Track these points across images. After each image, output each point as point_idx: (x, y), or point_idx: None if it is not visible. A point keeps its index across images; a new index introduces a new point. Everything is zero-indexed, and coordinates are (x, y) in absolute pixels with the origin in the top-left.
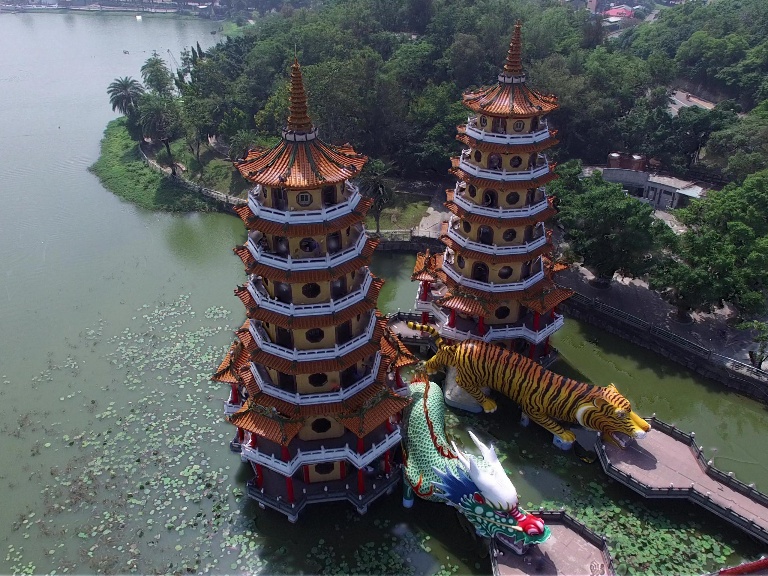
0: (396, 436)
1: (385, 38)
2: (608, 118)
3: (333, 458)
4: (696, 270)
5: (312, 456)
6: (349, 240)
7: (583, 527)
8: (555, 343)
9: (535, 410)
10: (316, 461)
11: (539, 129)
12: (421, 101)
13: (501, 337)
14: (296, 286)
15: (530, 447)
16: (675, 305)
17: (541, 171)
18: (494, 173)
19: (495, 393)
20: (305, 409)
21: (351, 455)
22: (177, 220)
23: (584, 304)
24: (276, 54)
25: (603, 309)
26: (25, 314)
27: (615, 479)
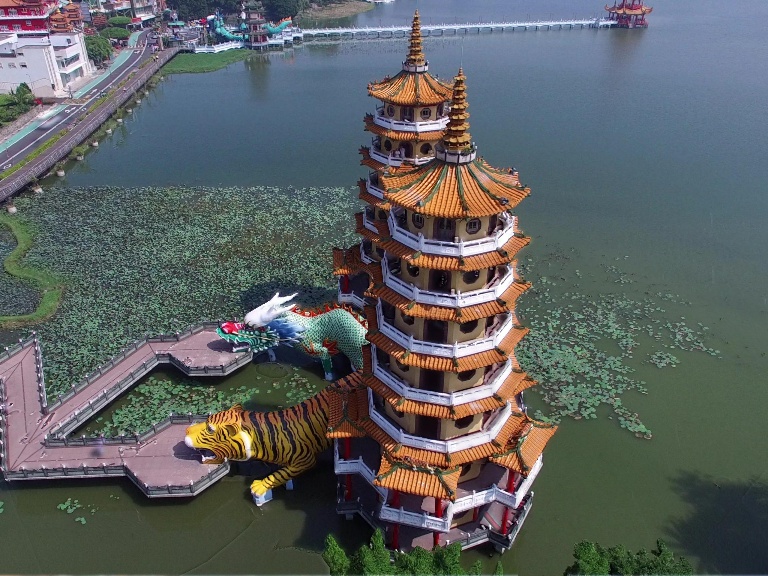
0: None
1: None
2: None
3: None
4: None
5: None
6: None
7: None
8: None
9: None
10: None
11: (406, 224)
12: None
13: None
14: None
15: None
16: None
17: None
18: None
19: None
20: None
21: None
22: None
23: None
24: None
25: None
26: (725, 277)
27: None
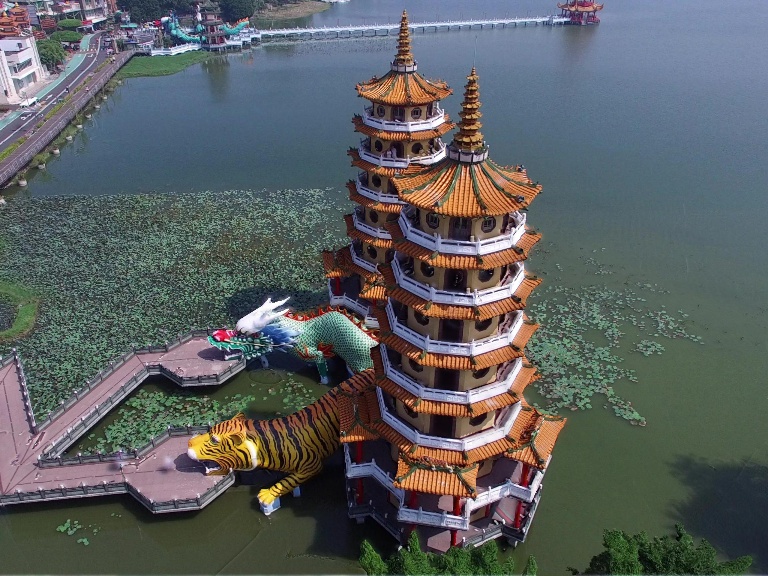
0: None
1: None
2: None
3: None
4: None
5: None
6: (373, 150)
7: None
8: None
9: None
10: None
11: (419, 225)
12: None
13: None
14: None
15: None
16: None
17: None
18: None
19: None
20: None
21: None
22: None
23: None
24: None
25: None
26: (699, 265)
27: None
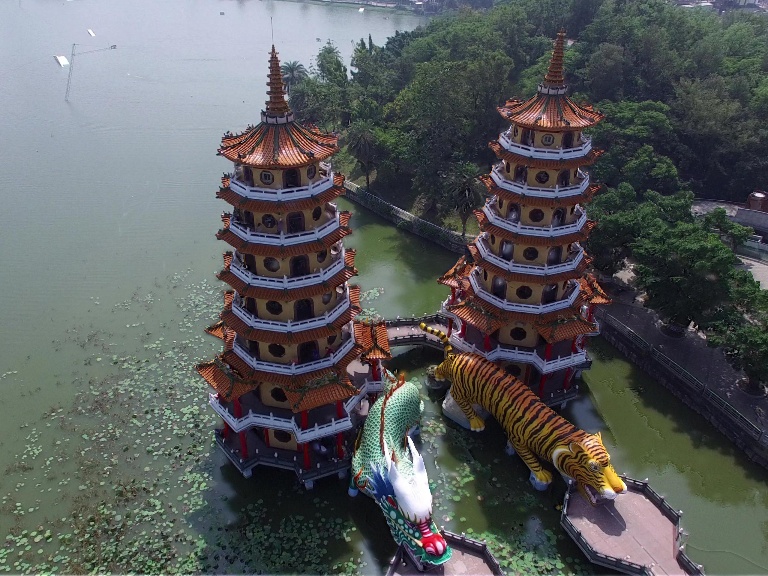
0: (345, 423)
1: (538, 43)
2: (765, 152)
3: (280, 427)
4: (765, 335)
5: (262, 420)
6: (314, 224)
7: (497, 566)
8: (592, 382)
9: (516, 440)
10: (265, 425)
11: (574, 146)
12: None
13: (509, 358)
14: (258, 258)
15: (503, 476)
16: (744, 371)
17: (571, 191)
18: (516, 186)
19: (485, 413)
20: (259, 374)
21: (295, 428)
22: None
23: (642, 348)
24: (427, 51)
25: (659, 358)
26: (138, 252)
27: (567, 532)
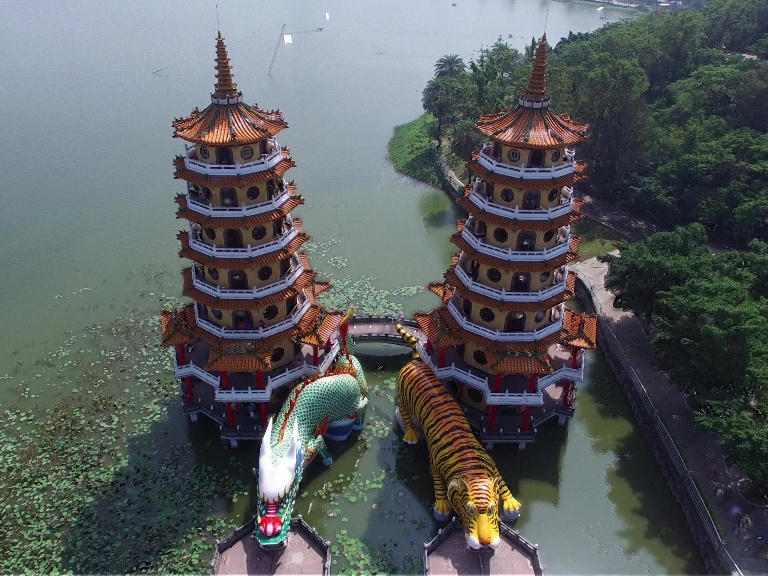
0: (263, 395)
1: (706, 55)
2: None
3: (211, 382)
4: (757, 430)
5: (199, 372)
6: (247, 202)
7: (326, 569)
8: (575, 433)
9: (431, 462)
10: (201, 377)
11: (546, 166)
12: (676, 132)
13: (462, 379)
14: None
15: (412, 494)
16: None
17: (535, 215)
18: (481, 200)
19: None
20: (199, 330)
21: None
22: (406, 185)
23: (648, 412)
24: (581, 55)
25: (660, 428)
26: None
27: (423, 566)
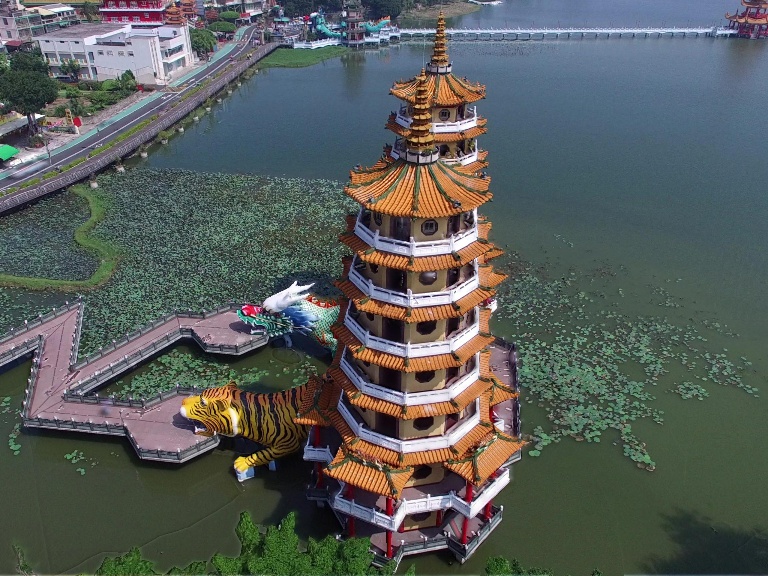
0: None
1: None
2: None
3: None
4: None
5: None
6: None
7: None
8: None
9: None
10: None
11: (370, 220)
12: None
13: None
14: None
15: None
16: None
17: None
18: None
19: None
20: None
21: None
22: None
23: None
24: None
25: None
26: None
27: None
